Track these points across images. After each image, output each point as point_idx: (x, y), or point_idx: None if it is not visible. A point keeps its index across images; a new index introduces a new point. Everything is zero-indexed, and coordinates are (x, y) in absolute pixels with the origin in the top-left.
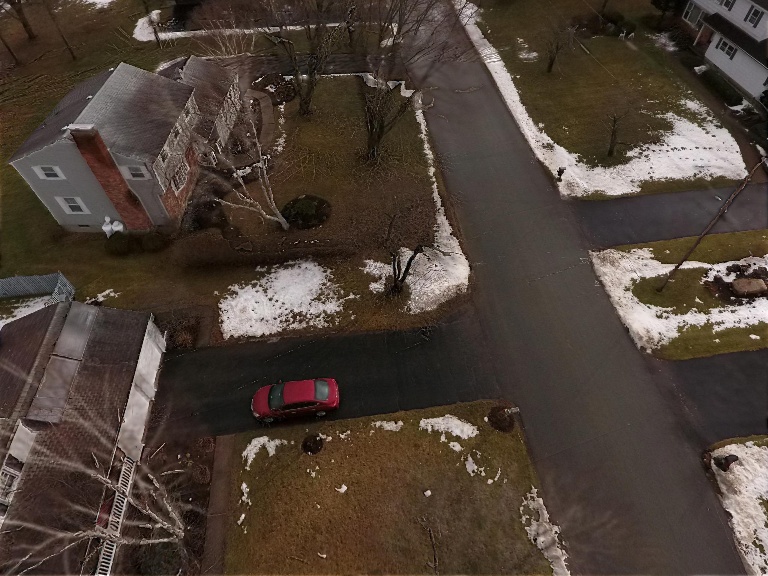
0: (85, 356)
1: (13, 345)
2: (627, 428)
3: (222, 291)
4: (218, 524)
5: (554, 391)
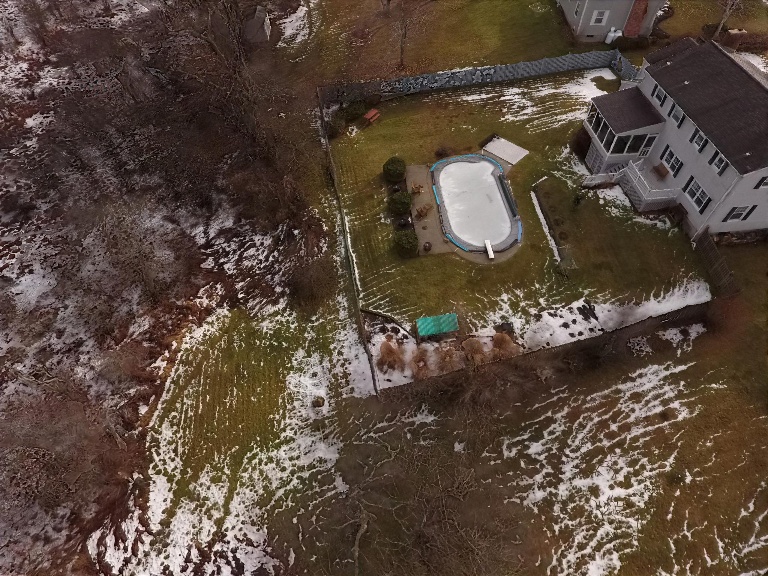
0: None
1: None
2: None
3: None
4: None
5: None
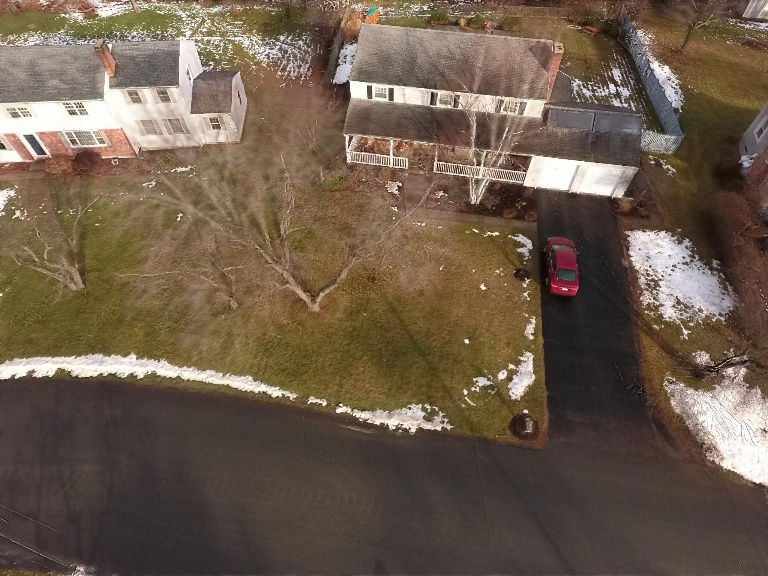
0: (597, 133)
1: (607, 107)
2: (493, 572)
3: (682, 234)
4: (475, 220)
5: (552, 504)
